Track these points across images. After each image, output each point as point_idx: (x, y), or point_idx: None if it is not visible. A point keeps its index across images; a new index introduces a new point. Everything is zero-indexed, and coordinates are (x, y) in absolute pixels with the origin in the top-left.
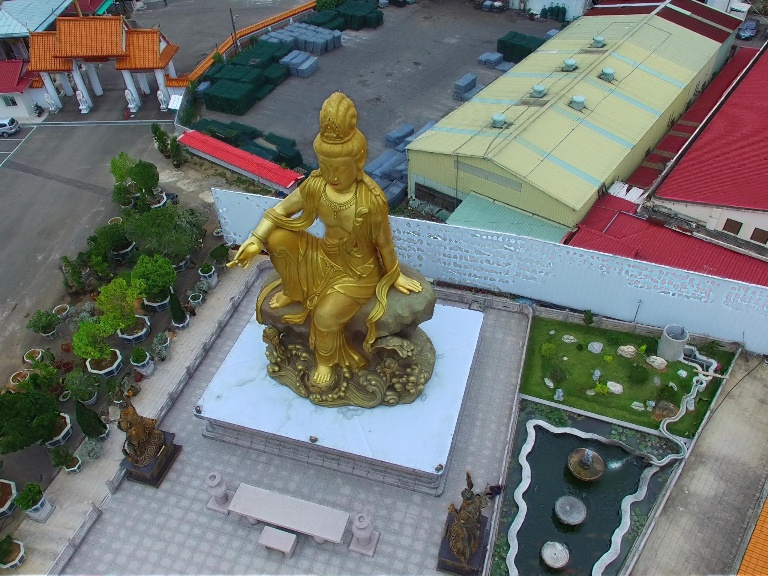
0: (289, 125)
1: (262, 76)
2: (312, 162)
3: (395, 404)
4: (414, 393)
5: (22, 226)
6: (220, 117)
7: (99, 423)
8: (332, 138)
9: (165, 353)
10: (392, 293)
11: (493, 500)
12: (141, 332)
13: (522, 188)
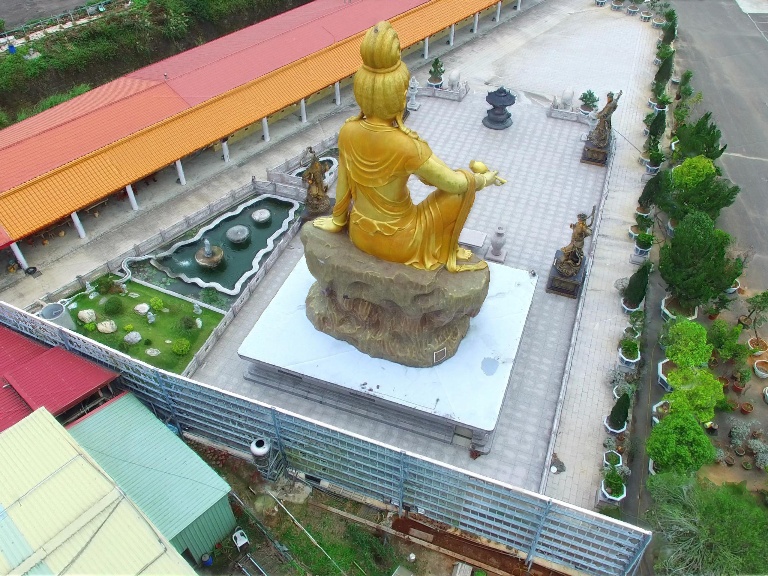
0: None
1: None
2: None
3: None
4: None
5: None
6: None
7: None
8: None
9: None
10: None
11: (290, 245)
12: (658, 406)
13: None
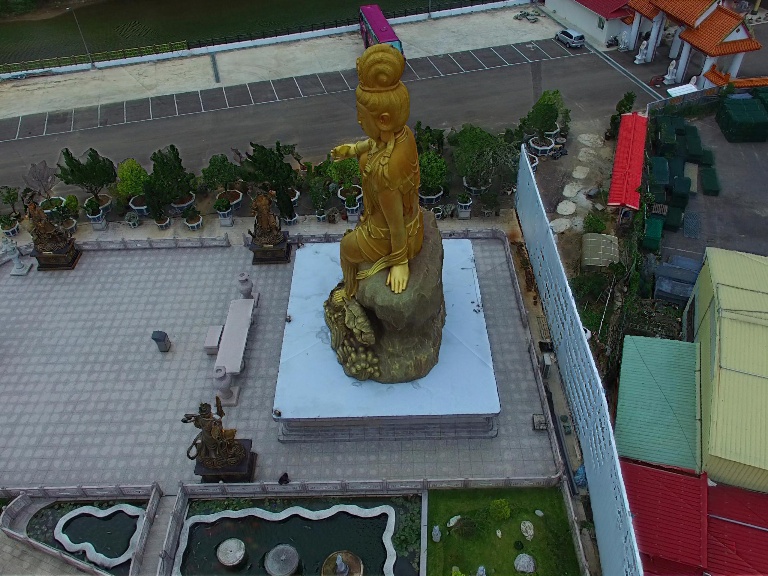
0: (749, 178)
1: None
2: (697, 216)
3: (340, 362)
4: None
5: (471, 101)
6: (711, 130)
7: (290, 211)
8: None
9: None
10: (384, 273)
11: None
12: None
13: None
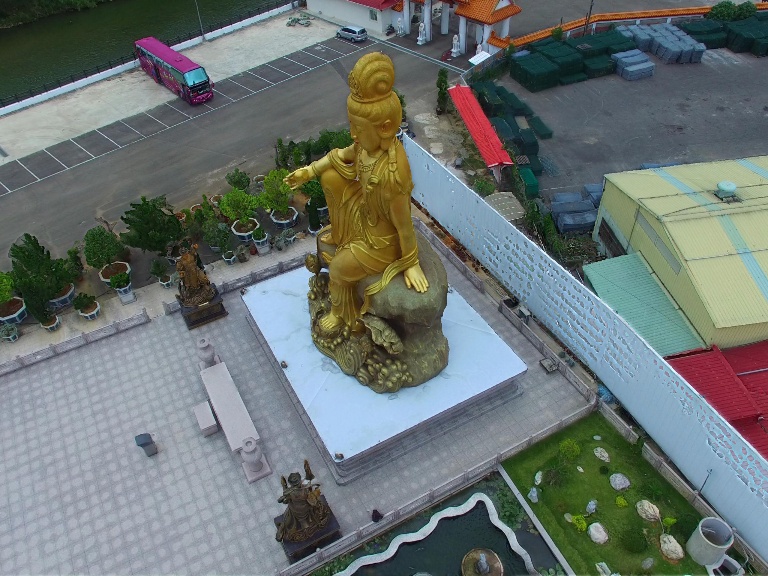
0: (565, 117)
1: (580, 63)
2: (549, 158)
3: (365, 384)
4: (382, 385)
5: (300, 110)
6: (513, 86)
7: (198, 263)
8: (354, 94)
9: (281, 244)
10: (398, 279)
11: None
12: (284, 221)
13: (680, 271)
